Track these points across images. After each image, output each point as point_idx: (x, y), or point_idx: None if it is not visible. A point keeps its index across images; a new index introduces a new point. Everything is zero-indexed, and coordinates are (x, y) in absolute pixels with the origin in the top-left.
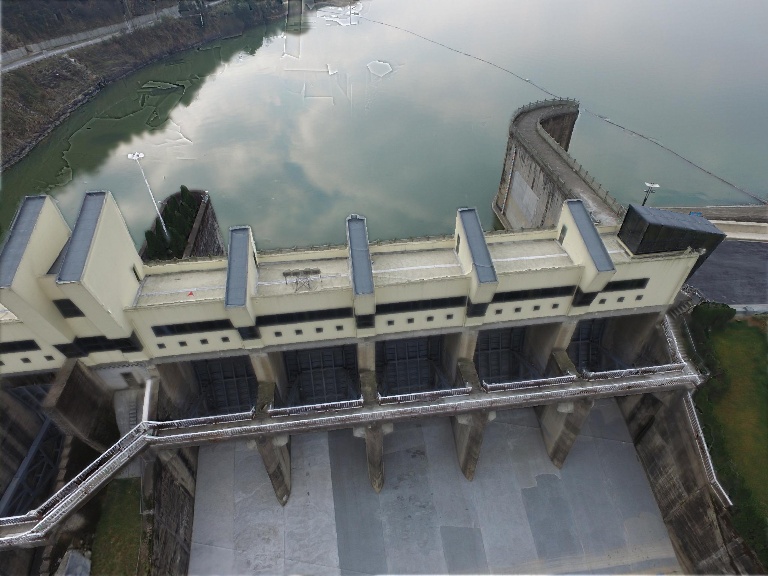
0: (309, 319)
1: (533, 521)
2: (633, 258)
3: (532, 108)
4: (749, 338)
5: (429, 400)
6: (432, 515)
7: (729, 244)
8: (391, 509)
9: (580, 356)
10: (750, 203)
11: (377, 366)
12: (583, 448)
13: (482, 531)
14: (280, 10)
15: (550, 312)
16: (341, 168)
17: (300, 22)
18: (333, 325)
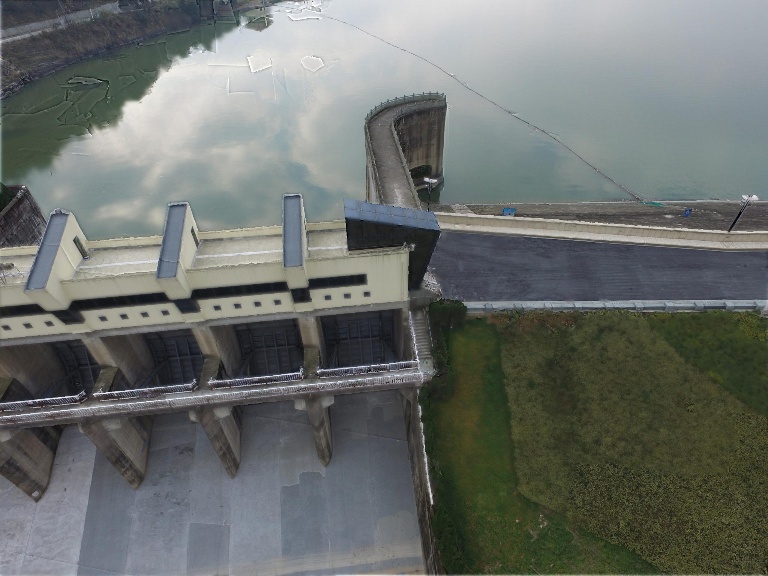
0: (11, 315)
1: (285, 519)
2: (350, 254)
3: (399, 103)
4: (484, 335)
5: (150, 397)
6: (185, 512)
7: (512, 240)
8: (145, 506)
9: (374, 353)
10: (623, 199)
11: (159, 362)
12: (355, 446)
13: (231, 528)
14: (233, 5)
15: (276, 308)
16: (231, 163)
17: (213, 16)
18: (40, 321)
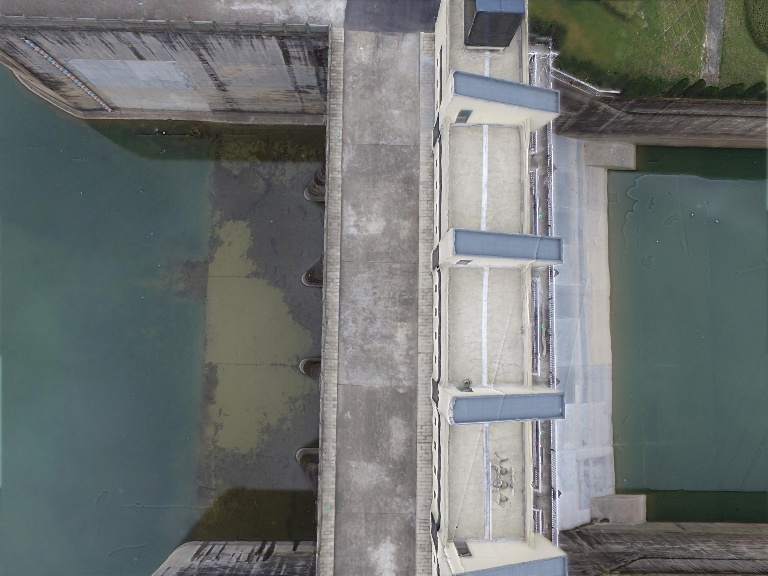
0: None
1: None
2: (504, 49)
3: None
4: None
5: None
6: None
7: None
8: None
9: None
10: None
11: None
12: None
13: None
14: None
15: None
16: None
17: None
18: None
